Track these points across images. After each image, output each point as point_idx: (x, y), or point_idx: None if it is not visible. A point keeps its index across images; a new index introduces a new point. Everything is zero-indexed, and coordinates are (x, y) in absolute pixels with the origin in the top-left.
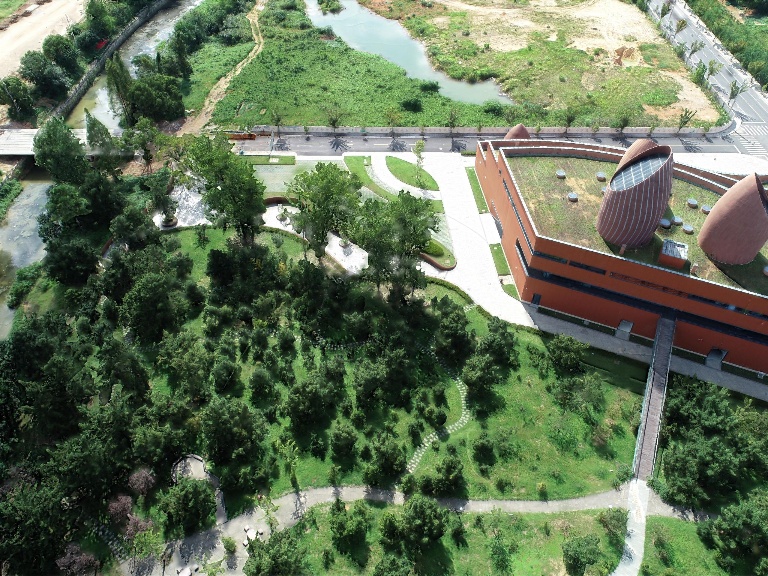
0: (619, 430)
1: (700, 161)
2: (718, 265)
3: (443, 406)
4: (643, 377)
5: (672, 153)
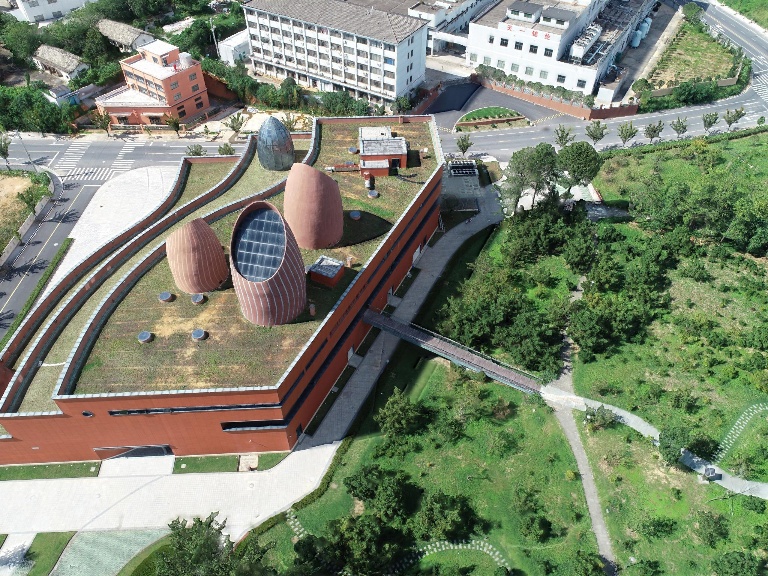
0: (484, 393)
1: (98, 218)
2: (341, 245)
3: (471, 574)
4: (413, 358)
5: (269, 204)
